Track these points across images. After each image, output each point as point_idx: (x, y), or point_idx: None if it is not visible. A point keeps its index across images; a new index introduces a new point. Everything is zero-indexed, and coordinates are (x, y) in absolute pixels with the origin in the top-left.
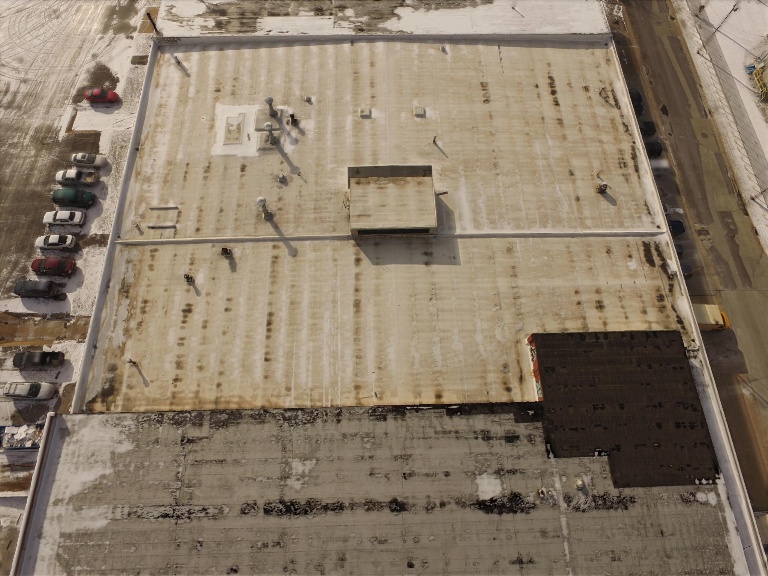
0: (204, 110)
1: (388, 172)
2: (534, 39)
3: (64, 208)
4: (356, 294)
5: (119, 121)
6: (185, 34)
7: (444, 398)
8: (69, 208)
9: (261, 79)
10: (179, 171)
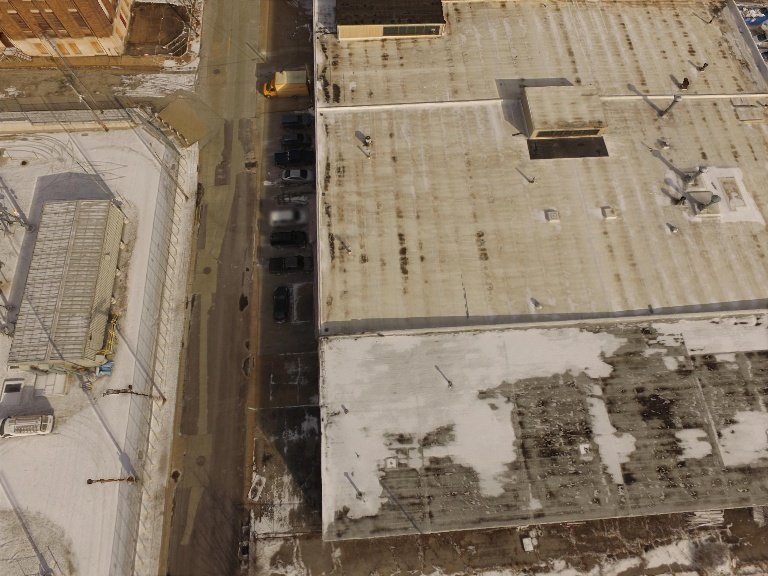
0: None
1: (571, 151)
2: None
3: None
4: (573, 59)
5: None
6: None
7: (500, 5)
8: None
9: (734, 256)
10: (760, 153)
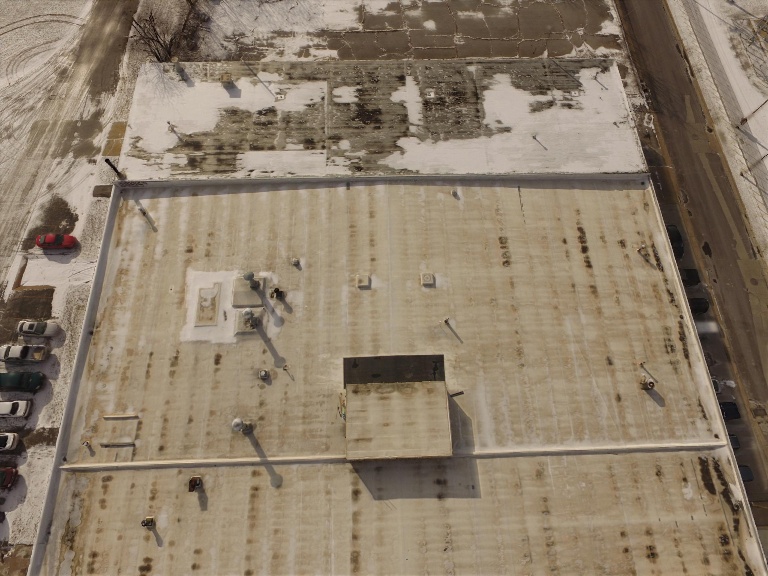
0: (173, 278)
1: (392, 365)
2: (559, 178)
3: (6, 393)
4: (354, 543)
5: (76, 273)
6: (152, 175)
7: None
8: (13, 393)
9: (241, 235)
10: (141, 364)
